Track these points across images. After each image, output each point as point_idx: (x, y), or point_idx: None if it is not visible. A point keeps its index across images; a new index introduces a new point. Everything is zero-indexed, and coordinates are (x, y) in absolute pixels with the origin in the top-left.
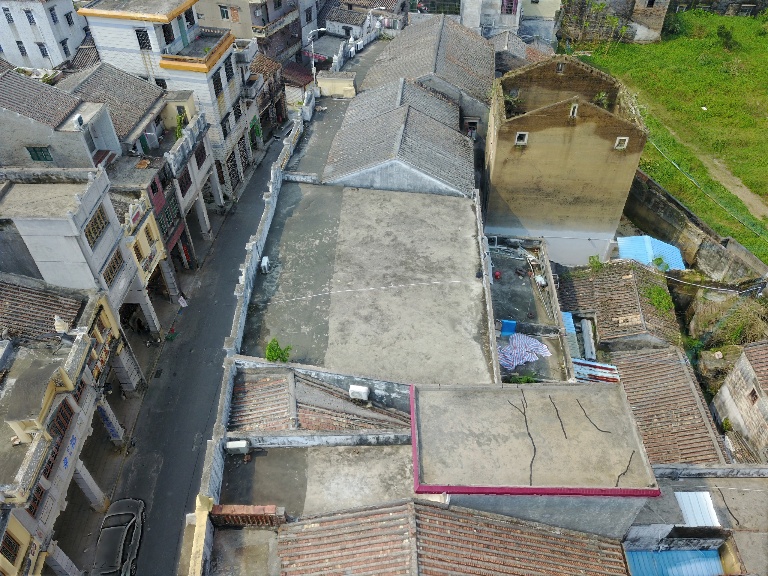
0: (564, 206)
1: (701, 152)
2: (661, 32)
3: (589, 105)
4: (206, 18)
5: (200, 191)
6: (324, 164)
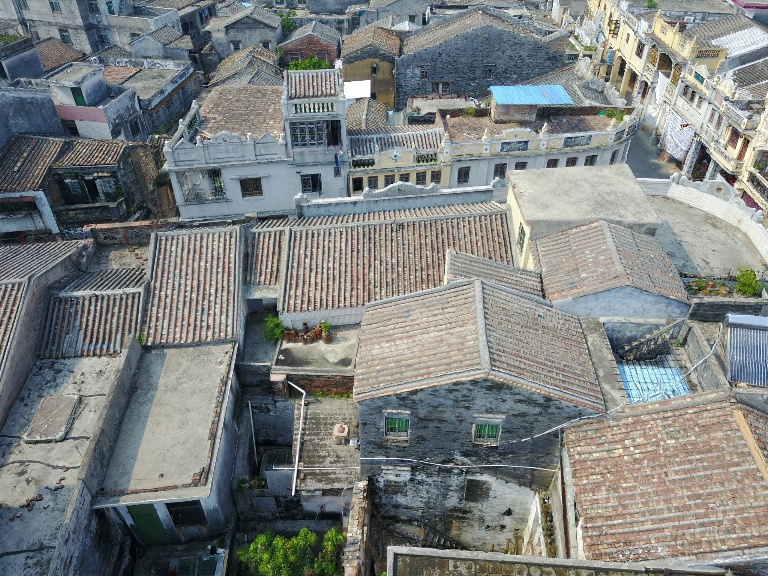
0: None
1: None
2: None
3: None
4: None
5: None
6: None
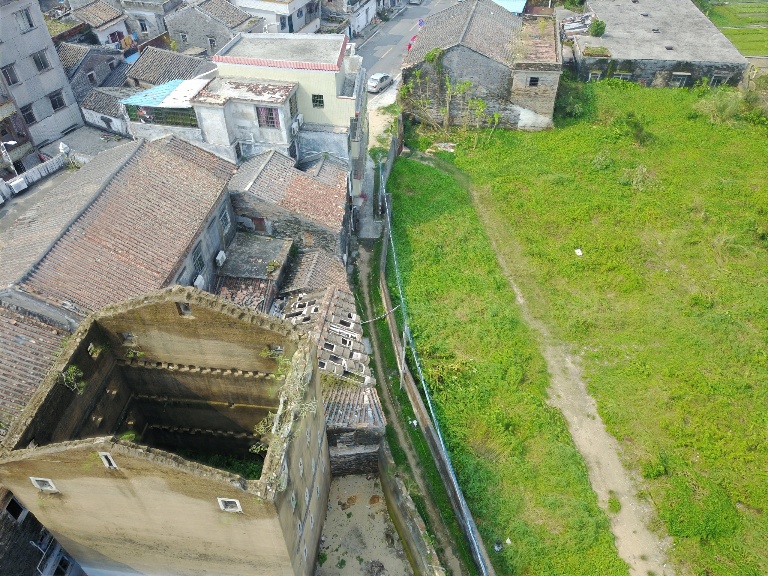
0: (190, 560)
1: (551, 340)
2: (559, 113)
3: (131, 456)
4: None
5: None
6: None
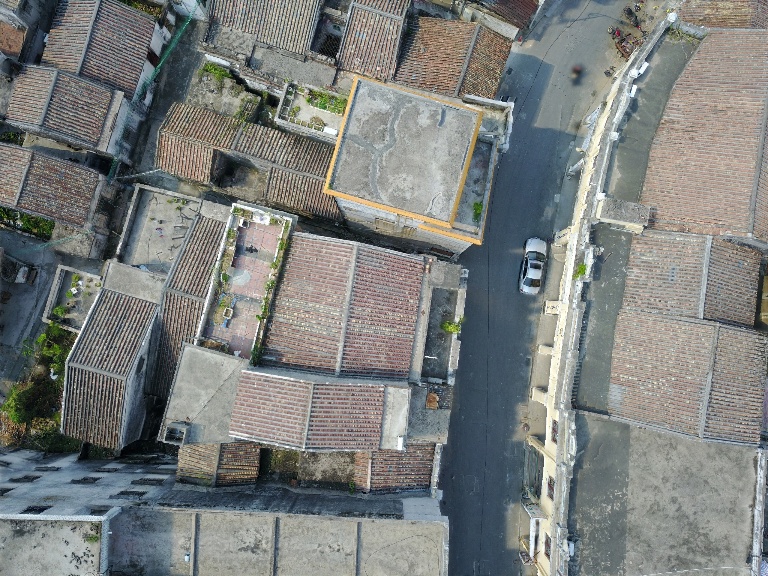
0: None
1: None
2: None
3: None
4: None
5: None
6: (608, 376)
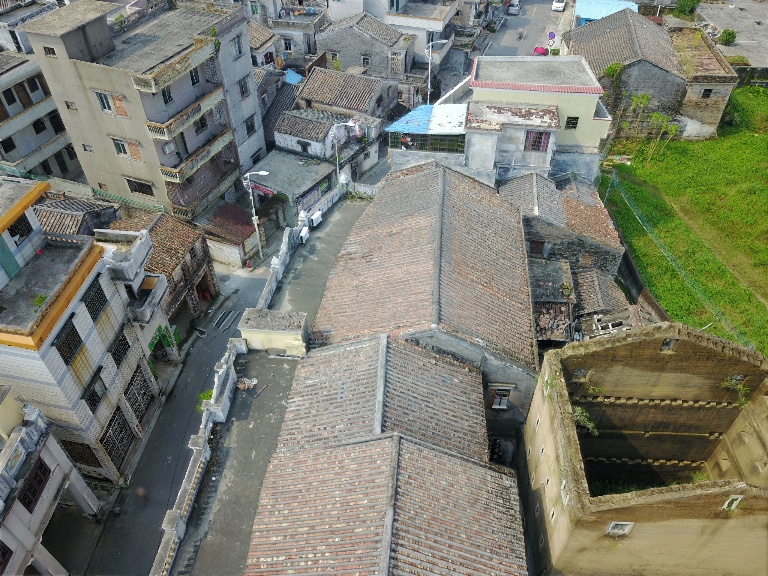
0: None
1: None
2: None
3: (765, 497)
4: (95, 151)
5: (37, 546)
6: (242, 566)
